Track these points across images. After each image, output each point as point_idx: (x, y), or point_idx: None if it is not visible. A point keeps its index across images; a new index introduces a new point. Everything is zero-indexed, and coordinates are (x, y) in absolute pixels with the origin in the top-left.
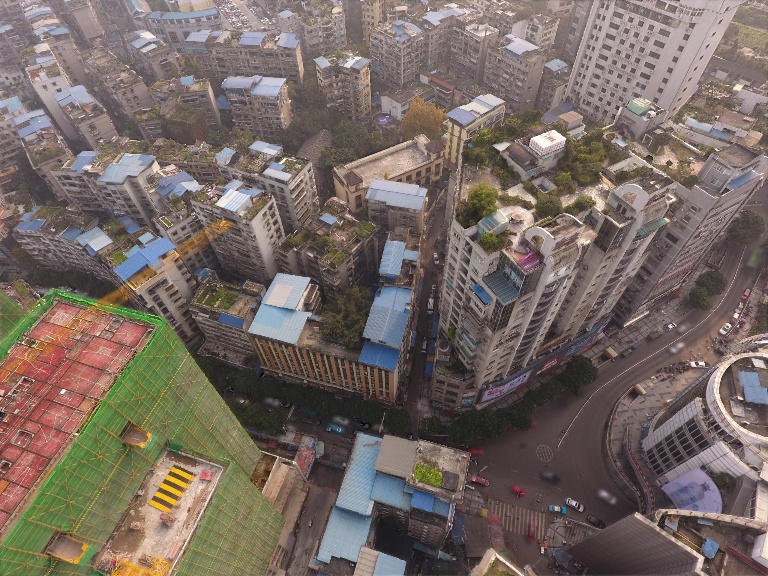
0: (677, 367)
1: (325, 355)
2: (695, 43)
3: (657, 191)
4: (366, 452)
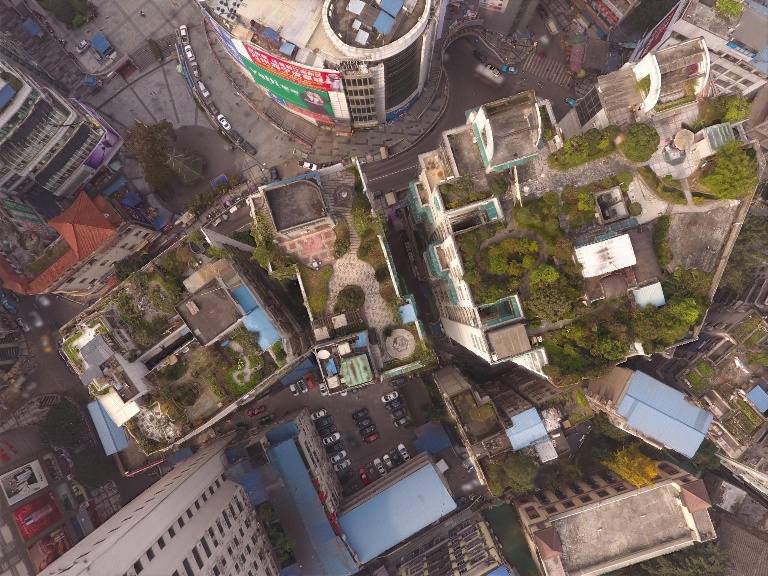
0: None
1: (767, 201)
2: (132, 545)
3: (517, 95)
4: None
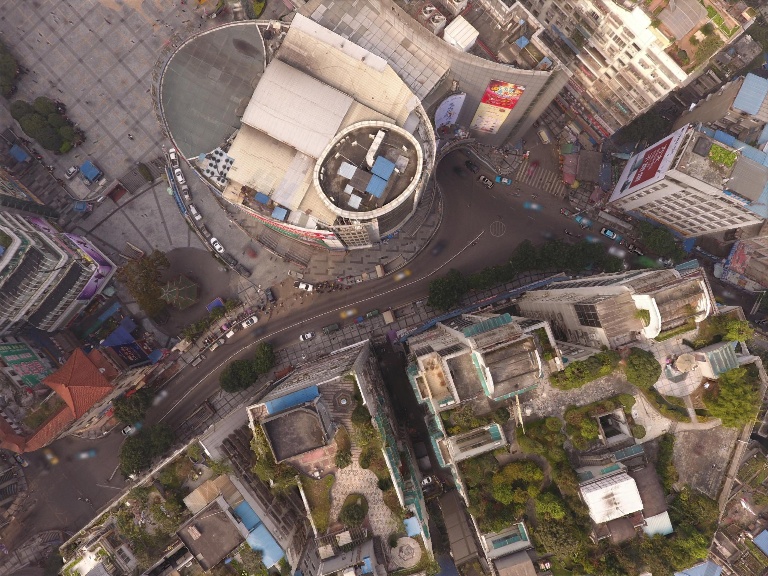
0: (328, 288)
1: (767, 333)
2: None
3: None
4: (763, 198)
